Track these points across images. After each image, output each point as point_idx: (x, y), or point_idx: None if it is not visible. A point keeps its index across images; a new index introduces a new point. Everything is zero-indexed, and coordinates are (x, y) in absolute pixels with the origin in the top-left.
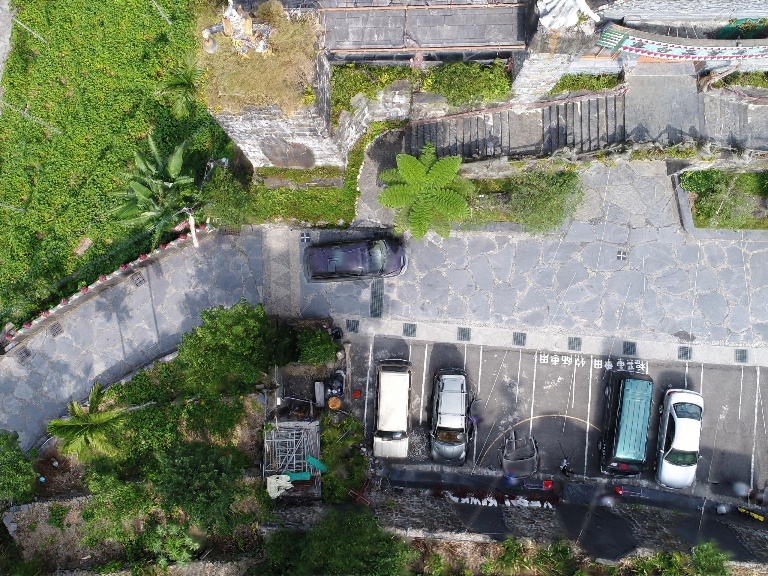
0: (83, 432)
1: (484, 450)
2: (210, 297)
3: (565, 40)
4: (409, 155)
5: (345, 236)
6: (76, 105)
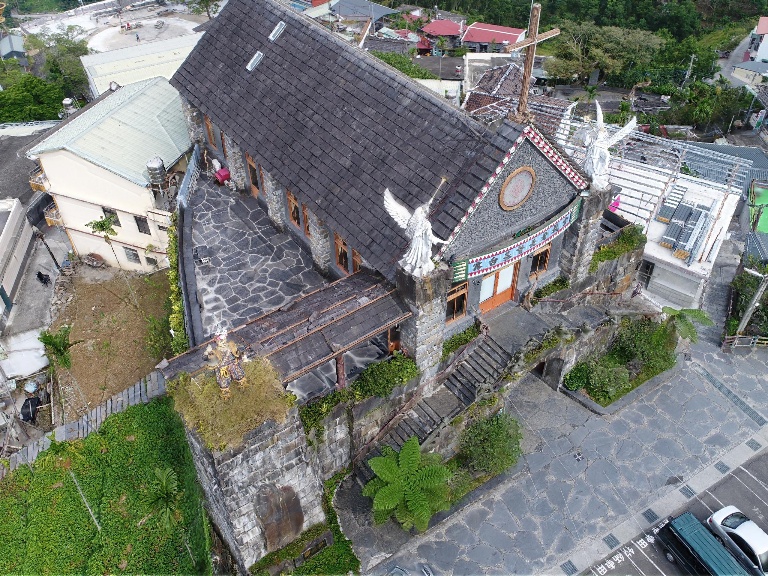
0: None
1: None
2: None
3: (435, 280)
4: (377, 457)
5: None
6: None
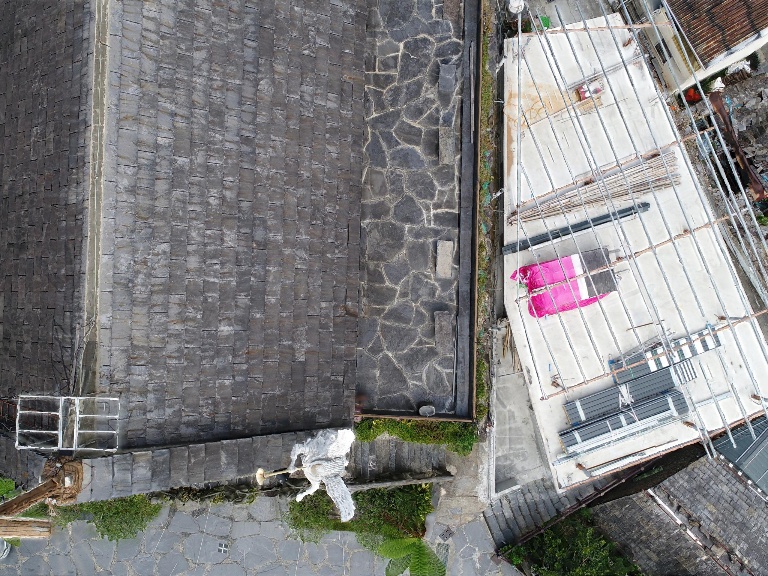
0: None
1: None
2: None
3: None
4: None
5: None
6: None
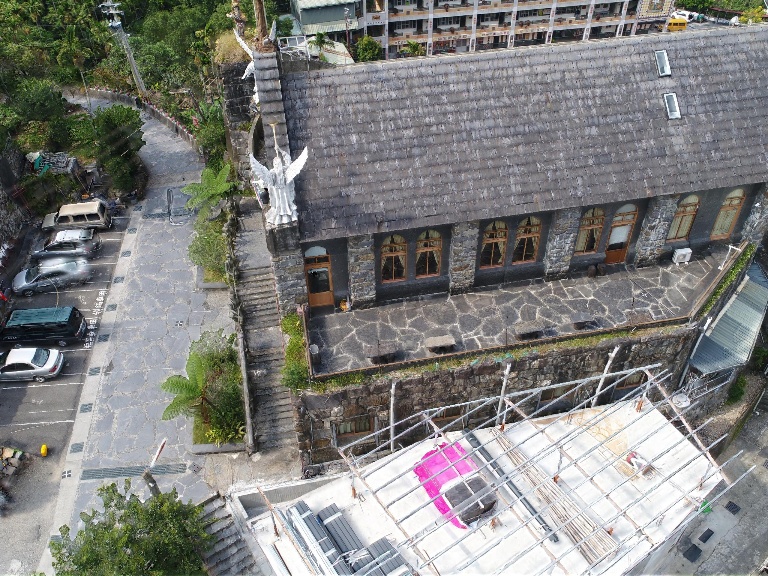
0: (67, 43)
1: (40, 272)
2: (162, 158)
3: None
4: None
5: None
6: None
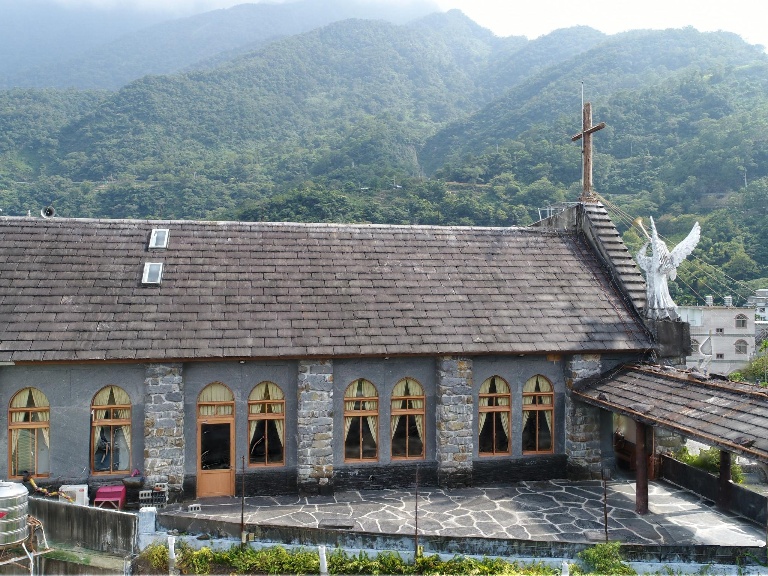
0: None
1: None
2: None
3: None
4: None
5: None
6: None
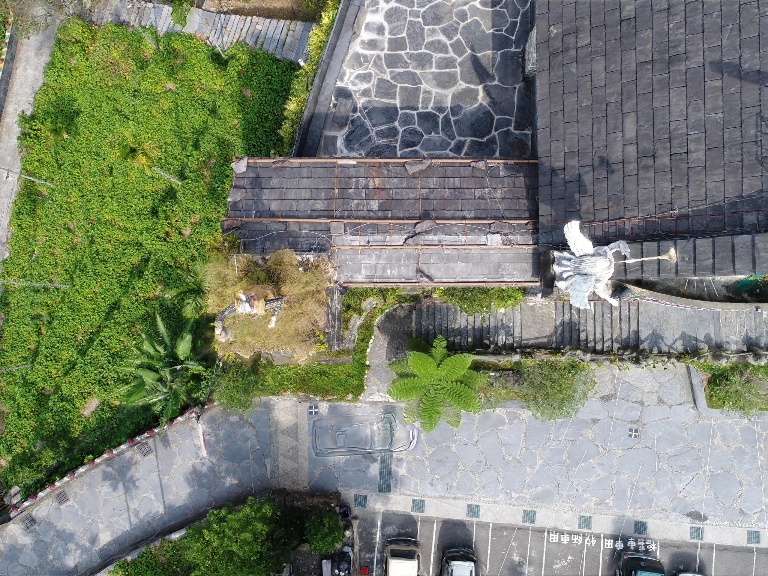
0: None
1: None
2: (217, 469)
3: None
4: None
5: (354, 409)
6: (84, 257)
